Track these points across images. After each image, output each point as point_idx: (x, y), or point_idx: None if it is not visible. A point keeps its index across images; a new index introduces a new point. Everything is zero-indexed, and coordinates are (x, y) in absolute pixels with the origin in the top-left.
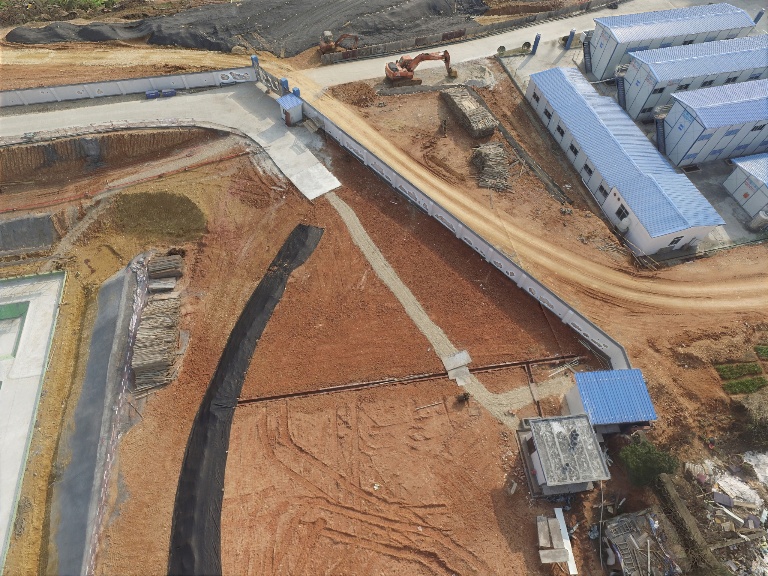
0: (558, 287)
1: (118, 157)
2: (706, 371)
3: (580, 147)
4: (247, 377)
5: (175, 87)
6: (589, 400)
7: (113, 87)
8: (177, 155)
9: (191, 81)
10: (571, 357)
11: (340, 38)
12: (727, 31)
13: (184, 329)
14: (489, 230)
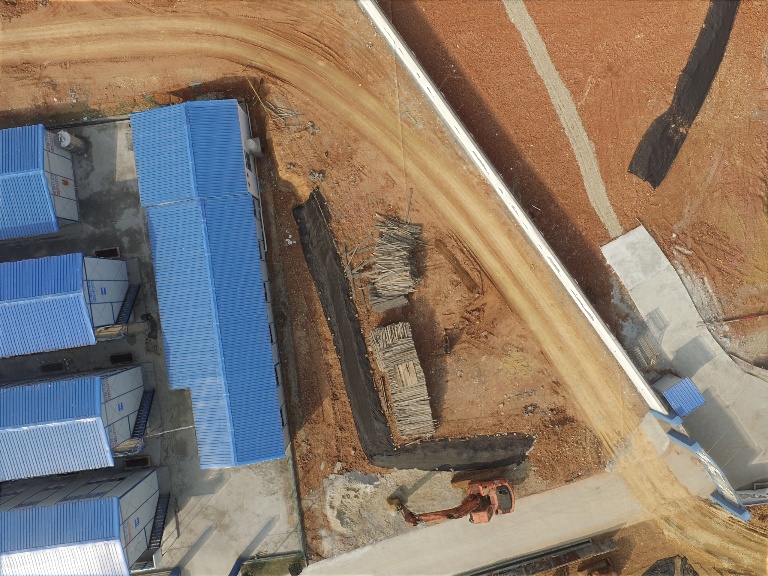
0: (364, 66)
1: None
2: None
3: None
4: None
5: None
6: None
7: None
8: None
9: None
10: None
11: None
12: None
13: None
14: (425, 153)
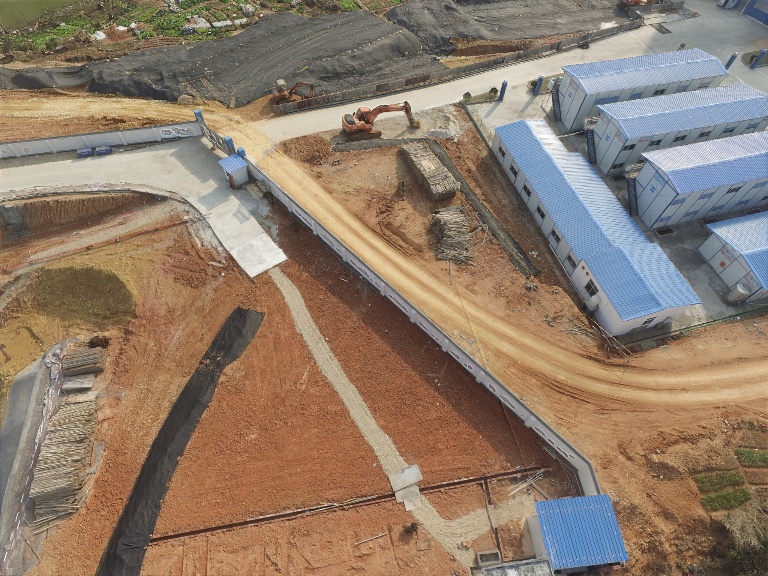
0: (521, 380)
1: (43, 225)
2: (683, 483)
3: (547, 212)
4: (164, 506)
5: (112, 143)
6: (551, 537)
7: (41, 145)
8: (109, 222)
9: (129, 137)
10: (534, 469)
11: (294, 87)
12: (699, 80)
13: (99, 440)
14: (447, 311)
